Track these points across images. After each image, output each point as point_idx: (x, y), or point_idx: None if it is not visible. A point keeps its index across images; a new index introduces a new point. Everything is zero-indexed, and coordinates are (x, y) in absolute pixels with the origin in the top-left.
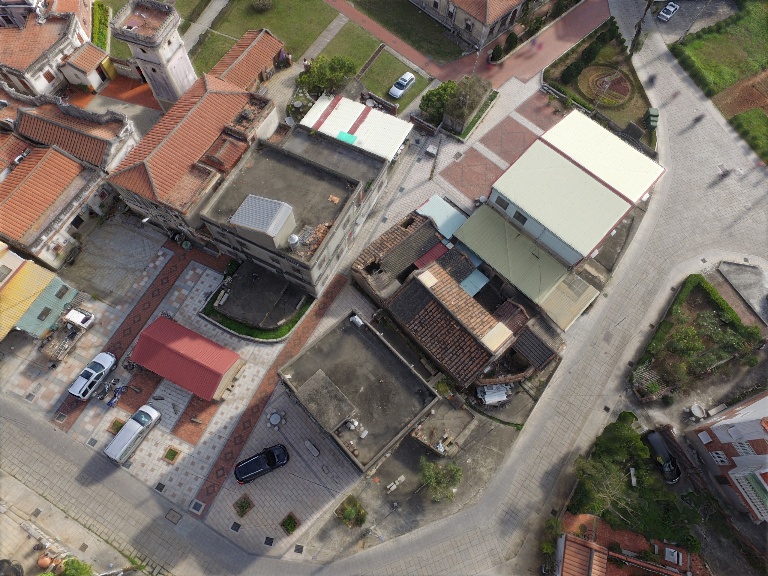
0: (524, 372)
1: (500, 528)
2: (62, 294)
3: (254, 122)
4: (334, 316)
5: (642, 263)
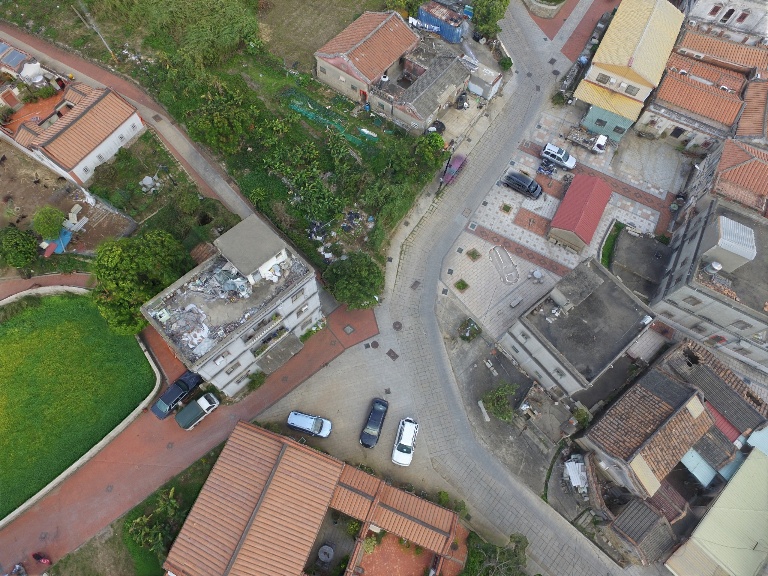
0: None
1: (456, 458)
2: (617, 131)
3: None
4: None
5: None
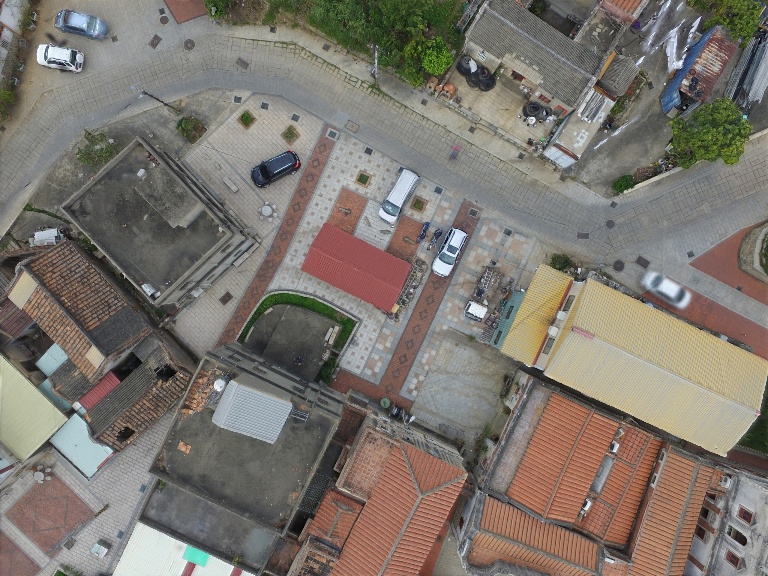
0: (6, 257)
1: (55, 116)
2: None
3: (300, 567)
4: (217, 322)
5: None
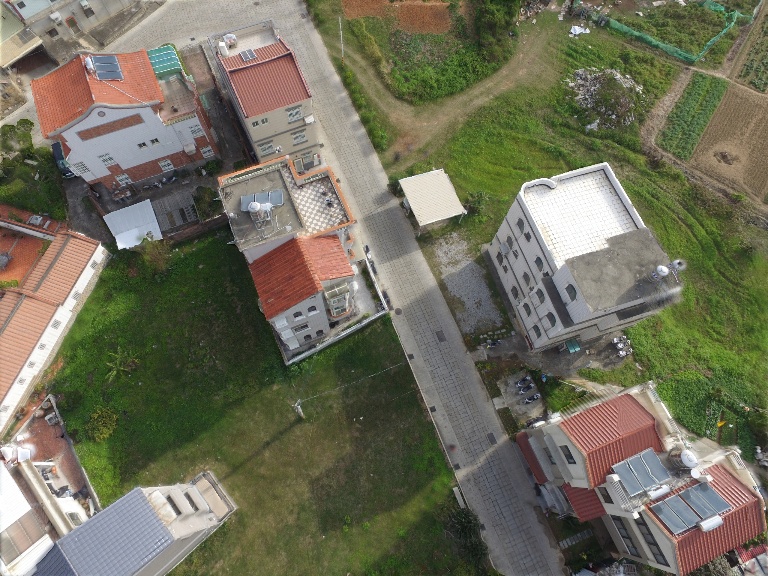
0: None
1: None
2: None
3: None
4: None
5: (136, 40)
